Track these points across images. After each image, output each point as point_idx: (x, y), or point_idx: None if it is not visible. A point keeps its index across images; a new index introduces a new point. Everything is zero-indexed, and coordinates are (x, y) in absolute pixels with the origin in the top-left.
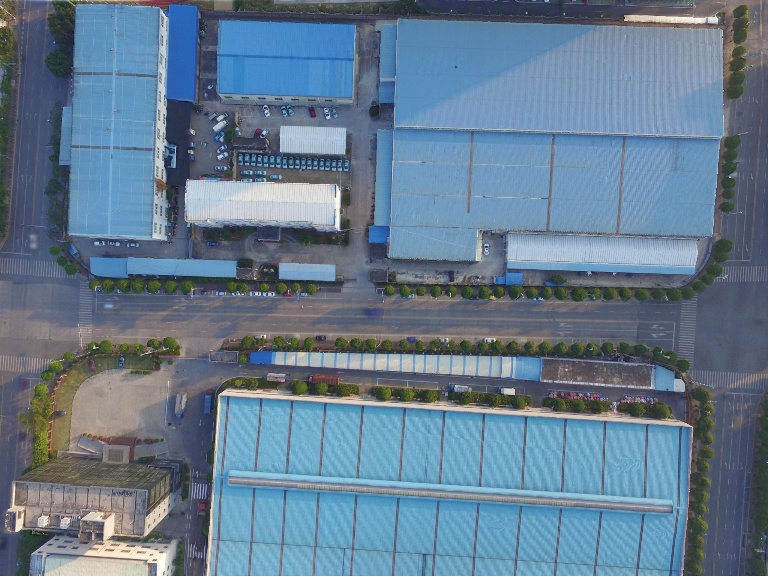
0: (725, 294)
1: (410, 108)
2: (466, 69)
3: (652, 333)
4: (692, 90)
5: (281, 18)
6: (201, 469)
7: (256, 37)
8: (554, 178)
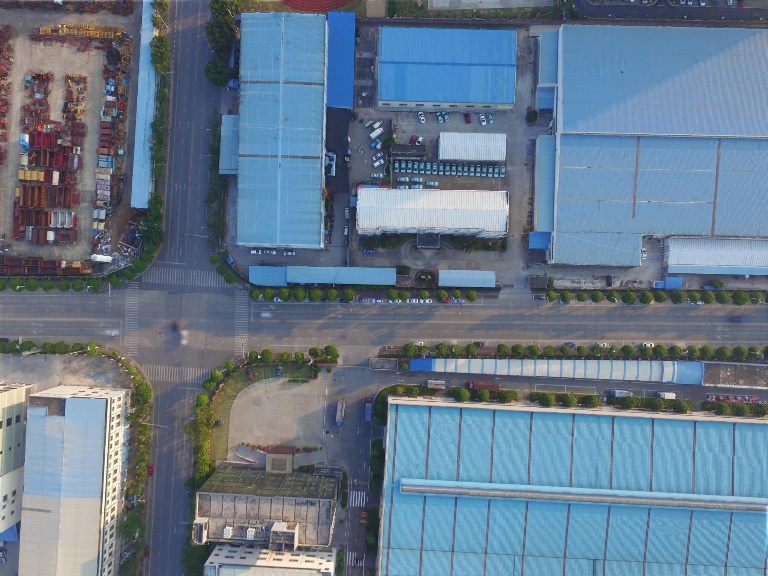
0: None
1: (577, 114)
2: (632, 74)
3: None
4: None
5: (435, 24)
6: (359, 477)
7: (417, 44)
8: (719, 182)
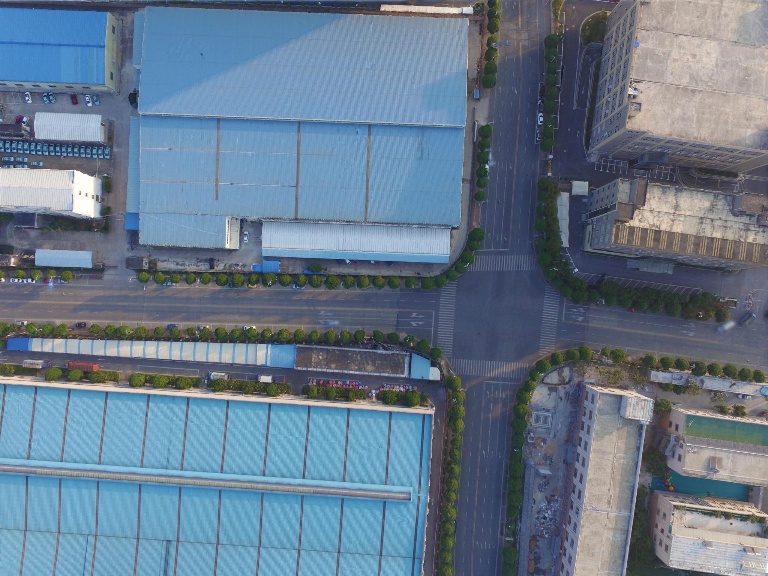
0: (484, 283)
1: (154, 95)
2: (212, 56)
3: (411, 321)
4: (436, 79)
5: (44, 5)
6: None
7: (8, 23)
8: (301, 166)
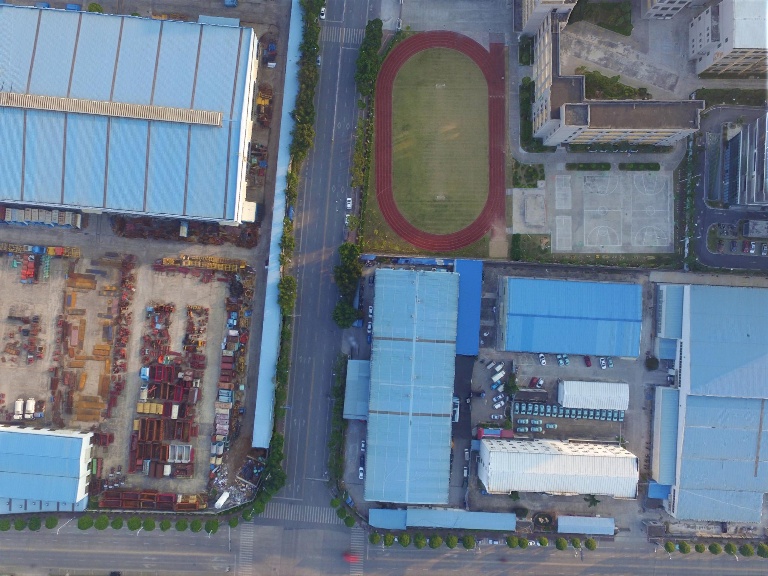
0: None
1: (704, 377)
2: (758, 338)
3: None
4: None
5: (557, 267)
6: None
7: (545, 296)
8: None
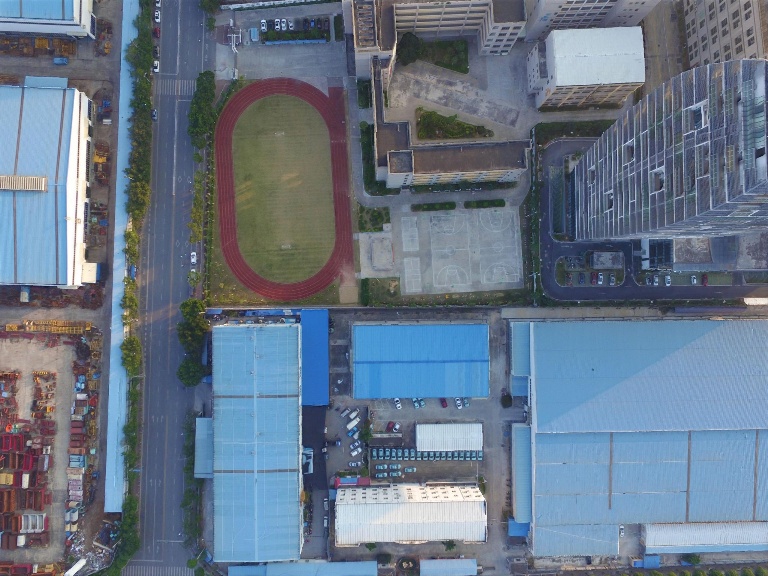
0: None
1: (551, 414)
2: (603, 371)
3: None
4: None
5: (408, 309)
6: None
7: (391, 342)
8: (691, 472)
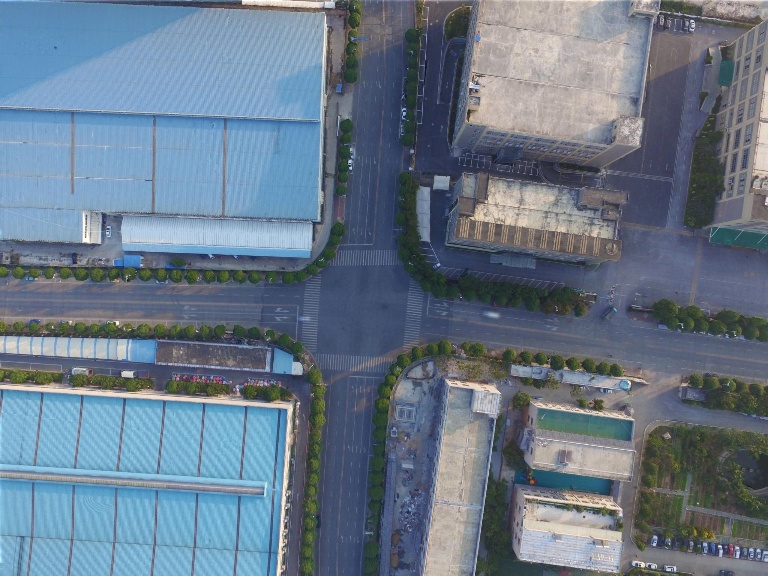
0: (348, 278)
1: (7, 88)
2: (65, 50)
3: (276, 316)
4: (291, 73)
5: None
6: None
7: None
8: (157, 160)
